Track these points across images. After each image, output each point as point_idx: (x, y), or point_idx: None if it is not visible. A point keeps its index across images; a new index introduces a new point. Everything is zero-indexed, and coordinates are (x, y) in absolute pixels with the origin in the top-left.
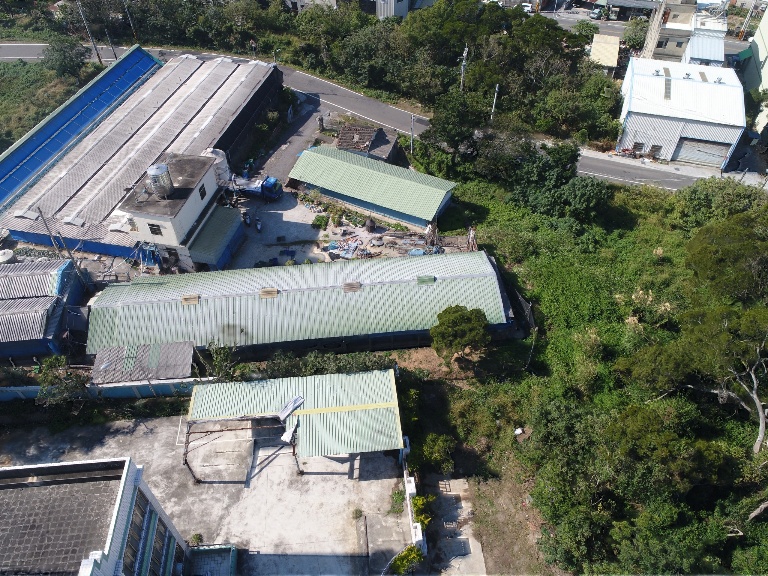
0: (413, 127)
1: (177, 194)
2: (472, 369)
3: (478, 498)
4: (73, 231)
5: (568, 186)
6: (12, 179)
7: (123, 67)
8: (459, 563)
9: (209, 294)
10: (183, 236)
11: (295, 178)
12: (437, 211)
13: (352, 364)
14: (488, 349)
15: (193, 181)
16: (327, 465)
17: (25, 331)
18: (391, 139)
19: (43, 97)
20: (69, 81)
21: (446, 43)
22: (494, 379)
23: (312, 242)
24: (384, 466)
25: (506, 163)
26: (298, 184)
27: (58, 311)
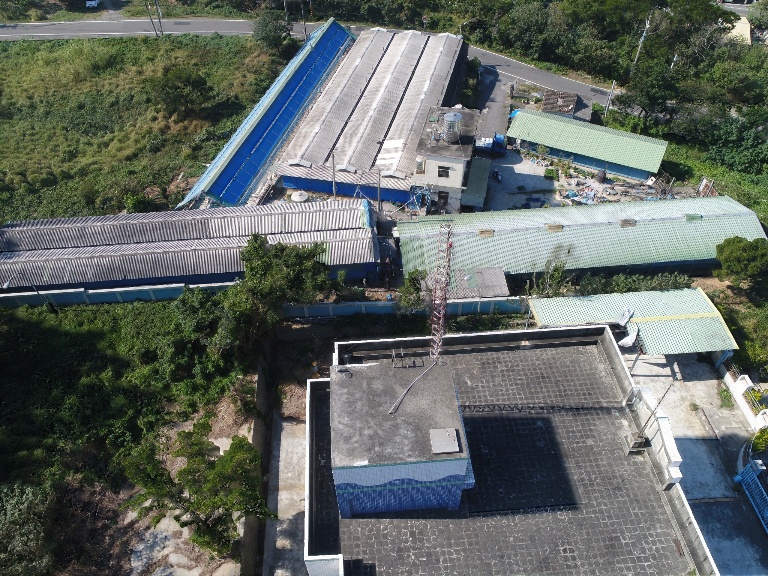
0: (612, 92)
1: (462, 140)
2: (745, 295)
3: None
4: (348, 177)
5: (767, 145)
6: (271, 134)
7: (327, 38)
8: None
9: (500, 228)
10: (462, 179)
11: (514, 137)
12: (660, 164)
13: (667, 282)
14: (753, 279)
15: (470, 130)
16: (650, 369)
17: (357, 255)
18: (588, 103)
19: (257, 65)
20: (269, 52)
21: (601, 20)
22: (767, 303)
23: (551, 191)
24: (702, 370)
25: (706, 124)
26: (509, 143)
27: (375, 240)
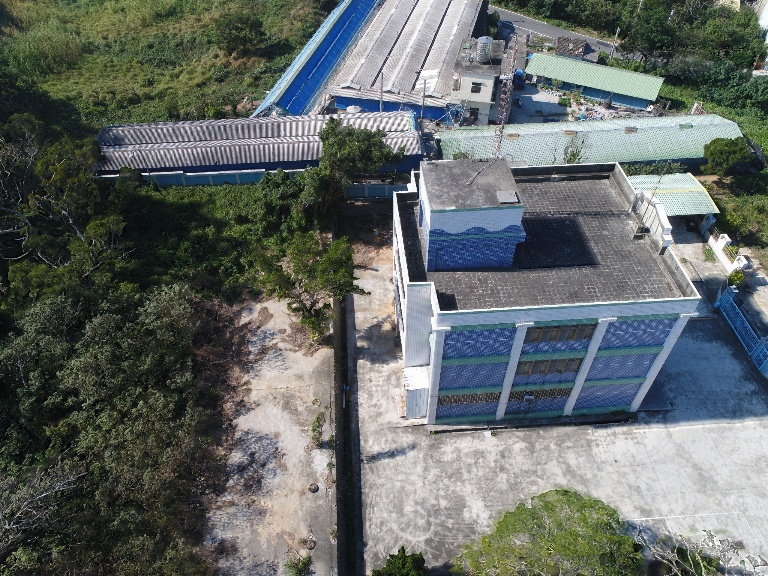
0: (616, 38)
1: (492, 62)
2: (727, 188)
3: (762, 257)
4: (392, 97)
5: (751, 82)
6: (323, 64)
7: None
8: (763, 289)
9: (524, 133)
10: (491, 96)
11: (531, 73)
12: None
13: (663, 167)
14: (734, 177)
15: (498, 55)
16: None
17: (407, 149)
18: (595, 49)
19: (302, 14)
20: (311, 6)
21: None
22: (746, 194)
23: (564, 114)
24: (690, 237)
25: (698, 65)
26: None
27: (421, 140)
